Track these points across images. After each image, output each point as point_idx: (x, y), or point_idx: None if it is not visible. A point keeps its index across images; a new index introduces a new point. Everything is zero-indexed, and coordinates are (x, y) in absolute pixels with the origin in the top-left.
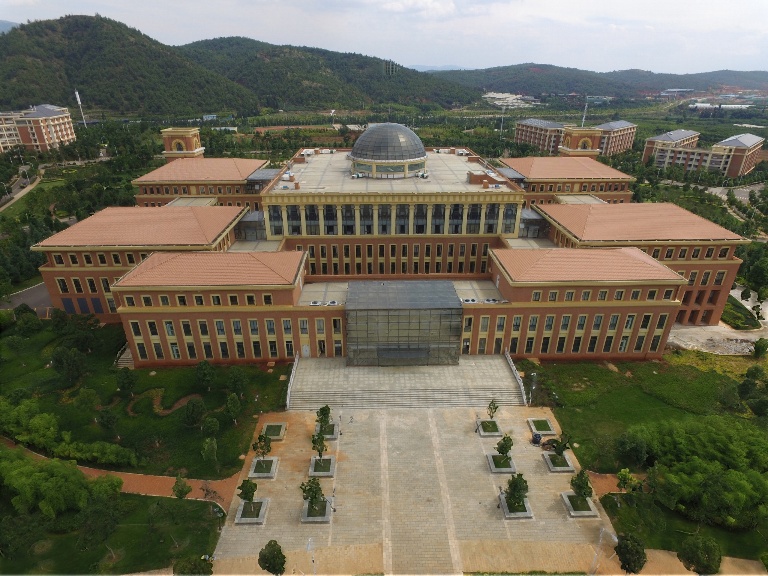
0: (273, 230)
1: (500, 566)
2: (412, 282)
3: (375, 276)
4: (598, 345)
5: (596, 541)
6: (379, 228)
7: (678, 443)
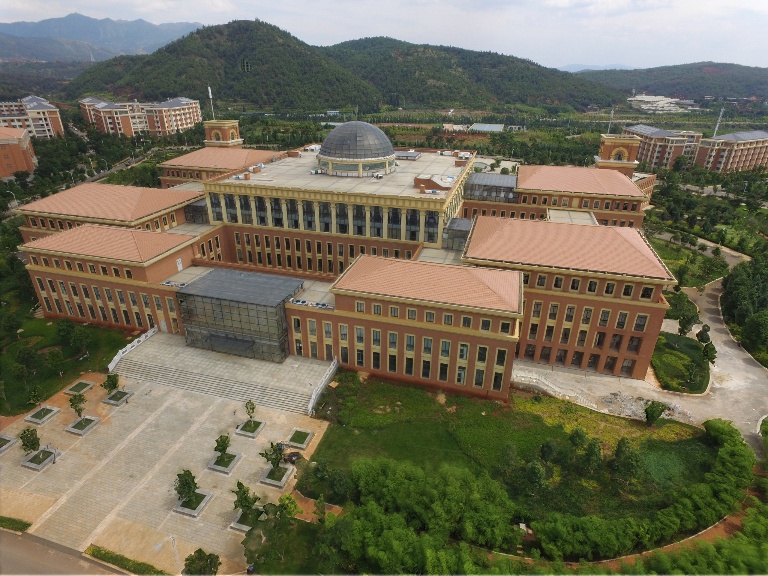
0: (215, 216)
1: (124, 549)
2: (268, 276)
3: (250, 267)
4: (432, 371)
5: (230, 556)
6: (305, 223)
7: (384, 485)
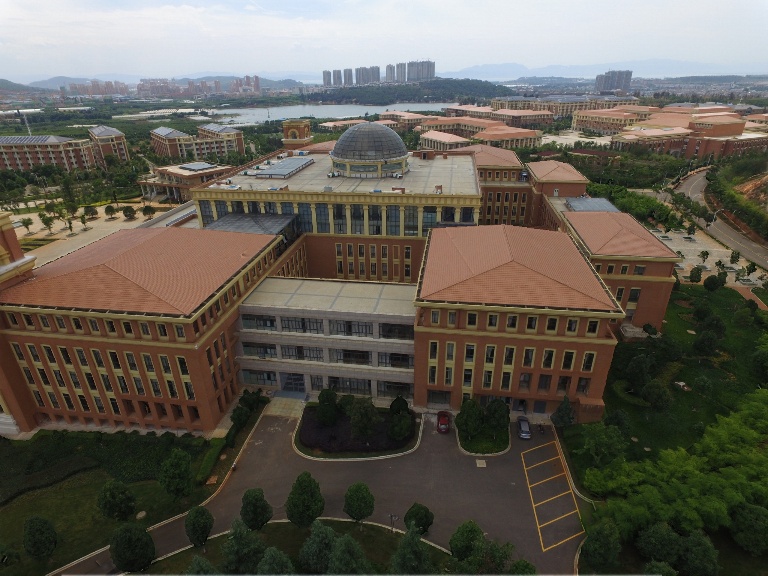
0: None
1: None
2: (572, 204)
3: None
4: None
5: None
6: None
7: (644, 206)
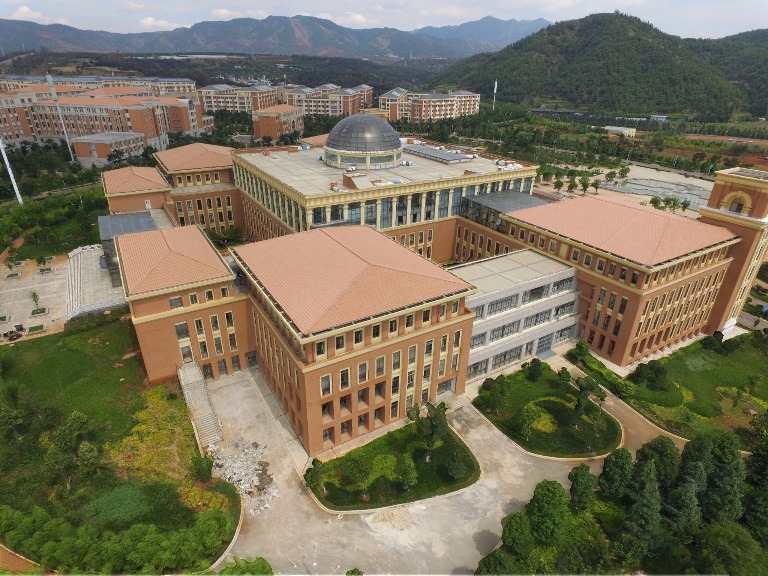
0: None
1: None
2: (152, 224)
3: None
4: None
5: None
6: None
7: None
